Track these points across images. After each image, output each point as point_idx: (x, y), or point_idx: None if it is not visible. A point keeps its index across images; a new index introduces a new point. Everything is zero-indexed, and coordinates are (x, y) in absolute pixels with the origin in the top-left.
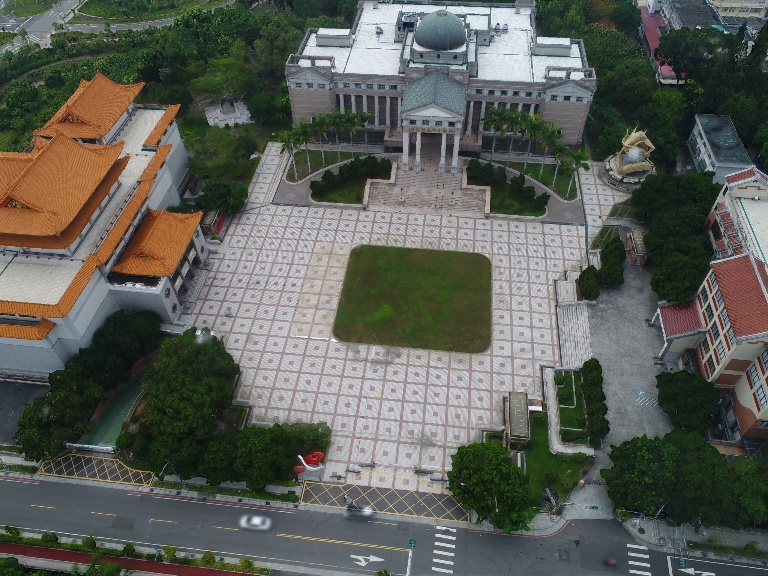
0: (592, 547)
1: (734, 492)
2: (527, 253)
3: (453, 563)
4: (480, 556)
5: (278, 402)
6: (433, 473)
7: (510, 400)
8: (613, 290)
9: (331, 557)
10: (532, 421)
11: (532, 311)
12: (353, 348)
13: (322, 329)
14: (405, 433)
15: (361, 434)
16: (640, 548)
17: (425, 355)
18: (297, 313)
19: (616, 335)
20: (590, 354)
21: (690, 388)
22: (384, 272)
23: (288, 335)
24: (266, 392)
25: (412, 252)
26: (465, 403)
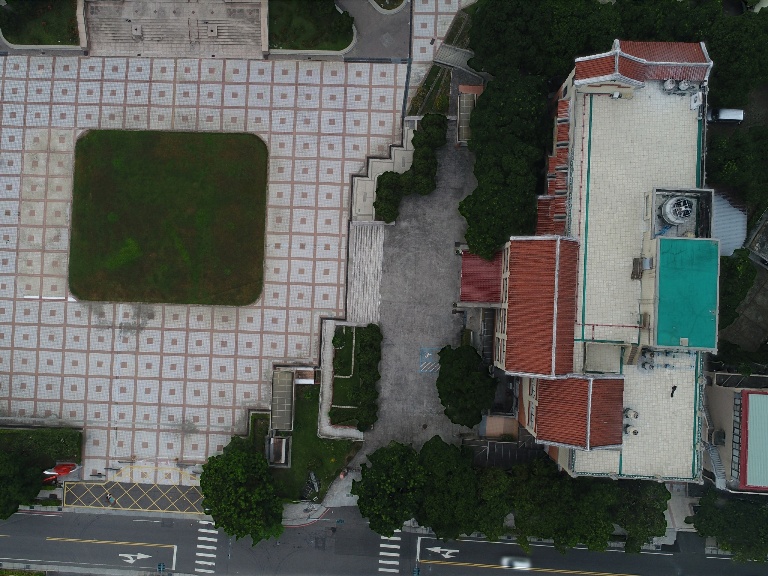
0: (348, 534)
1: (474, 519)
2: (319, 127)
3: (215, 556)
4: (241, 548)
5: (20, 391)
6: (195, 465)
7: (273, 384)
8: (423, 196)
9: (101, 557)
10: (302, 396)
11: (317, 233)
12: (96, 309)
13: (55, 284)
14: (164, 419)
15: (117, 424)
16: (394, 531)
17: (183, 313)
18: (20, 260)
19: (414, 272)
20: (378, 303)
21: (464, 386)
22: (123, 181)
23: (15, 296)
24: (4, 379)
25: (159, 139)
26: (230, 376)
